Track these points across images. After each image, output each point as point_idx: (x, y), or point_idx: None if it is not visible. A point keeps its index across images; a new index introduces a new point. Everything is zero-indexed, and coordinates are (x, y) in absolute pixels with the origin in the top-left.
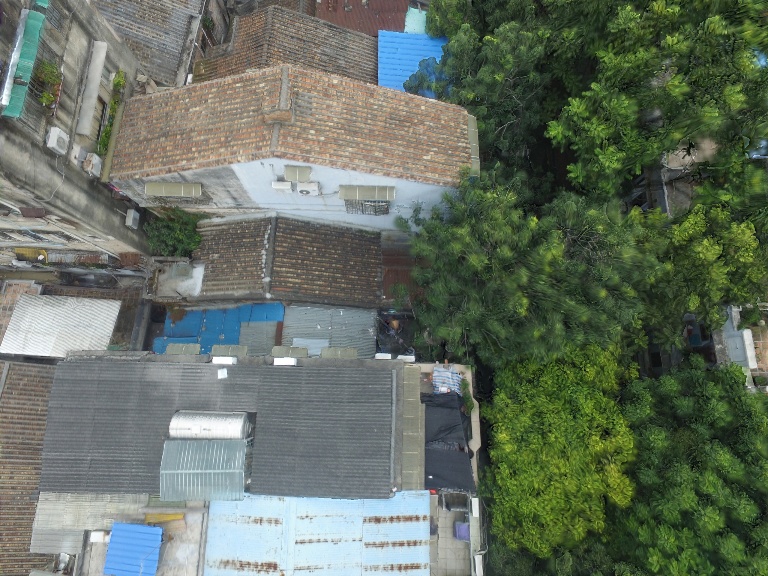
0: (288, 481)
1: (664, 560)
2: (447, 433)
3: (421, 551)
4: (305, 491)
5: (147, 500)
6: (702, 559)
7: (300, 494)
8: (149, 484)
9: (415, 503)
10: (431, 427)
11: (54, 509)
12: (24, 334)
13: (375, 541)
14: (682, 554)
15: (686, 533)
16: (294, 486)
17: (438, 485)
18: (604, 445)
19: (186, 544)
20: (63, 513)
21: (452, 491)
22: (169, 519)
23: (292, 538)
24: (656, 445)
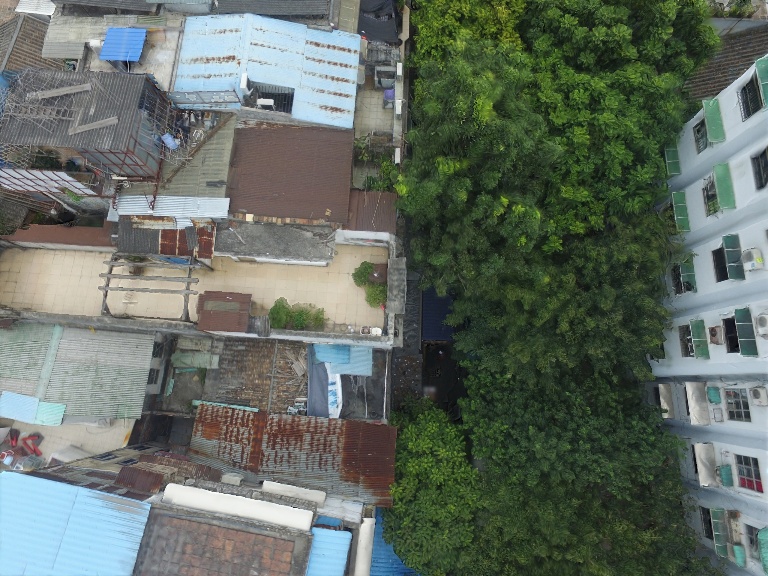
0: (247, 4)
1: (536, 61)
2: (379, 7)
3: (351, 72)
4: (260, 10)
5: (136, 22)
6: (566, 66)
7: (256, 11)
8: (138, 3)
9: (348, 41)
10: (367, 4)
11: (61, 30)
12: (37, 0)
13: (314, 57)
14: (550, 57)
15: (556, 52)
16: (252, 7)
17: (369, 38)
18: (501, 4)
19: (165, 50)
20: (69, 32)
21: (380, 45)
22: (152, 30)
23: (248, 40)
24: (542, 7)
